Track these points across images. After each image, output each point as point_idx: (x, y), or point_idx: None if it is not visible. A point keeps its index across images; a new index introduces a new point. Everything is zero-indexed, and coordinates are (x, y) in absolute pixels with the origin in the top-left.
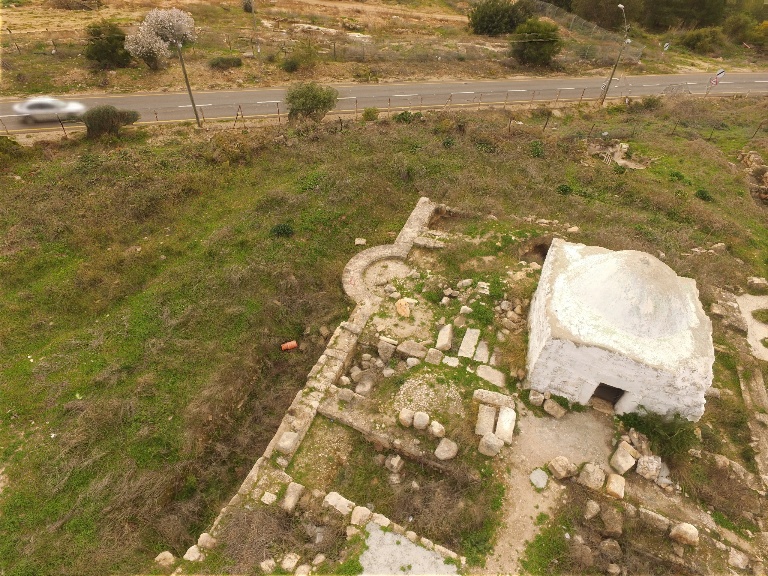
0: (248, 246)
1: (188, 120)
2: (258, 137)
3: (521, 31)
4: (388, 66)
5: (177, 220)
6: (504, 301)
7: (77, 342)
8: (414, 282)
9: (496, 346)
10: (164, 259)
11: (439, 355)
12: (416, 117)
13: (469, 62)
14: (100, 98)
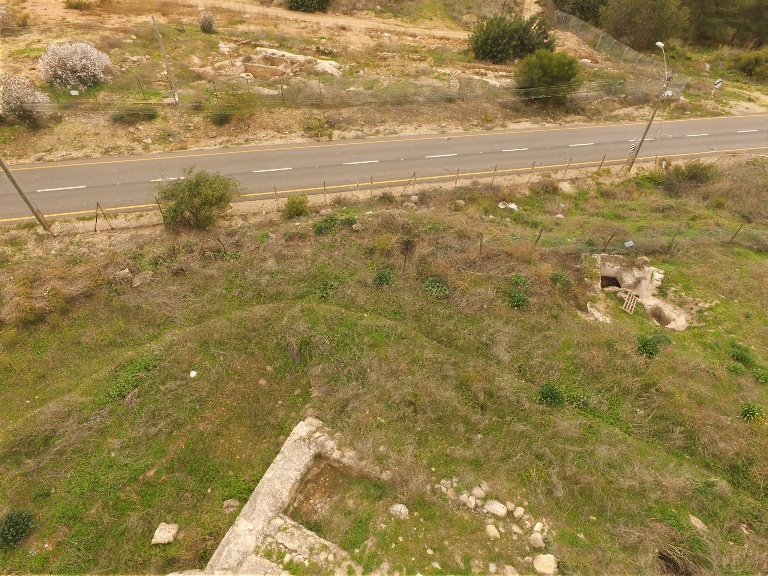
0: None
1: None
2: (90, 271)
3: (528, 64)
4: (352, 113)
5: None
6: None
7: None
8: None
9: None
10: None
11: None
12: (346, 224)
13: None
14: None
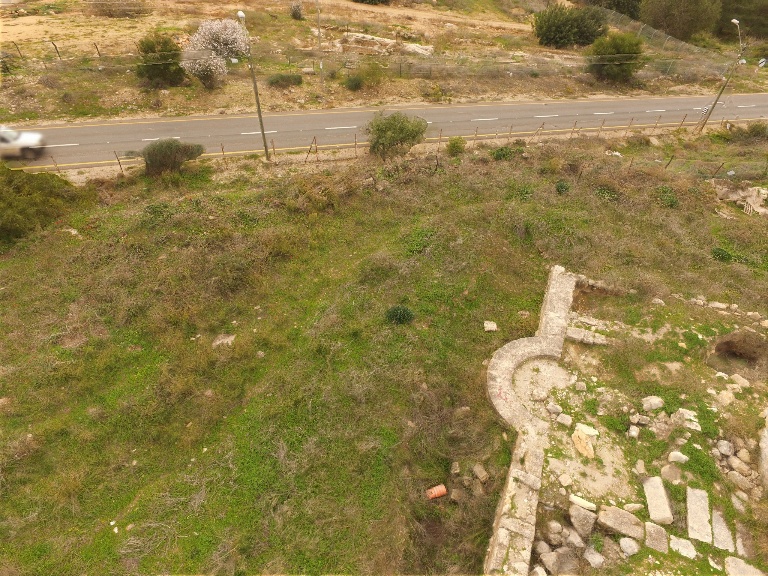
0: (362, 338)
1: (254, 151)
2: (344, 179)
3: (601, 44)
4: (458, 83)
5: (268, 296)
6: (723, 442)
7: (173, 500)
8: (580, 396)
9: (737, 521)
10: (262, 357)
11: (663, 535)
12: (517, 153)
13: (543, 78)
14: (154, 123)
